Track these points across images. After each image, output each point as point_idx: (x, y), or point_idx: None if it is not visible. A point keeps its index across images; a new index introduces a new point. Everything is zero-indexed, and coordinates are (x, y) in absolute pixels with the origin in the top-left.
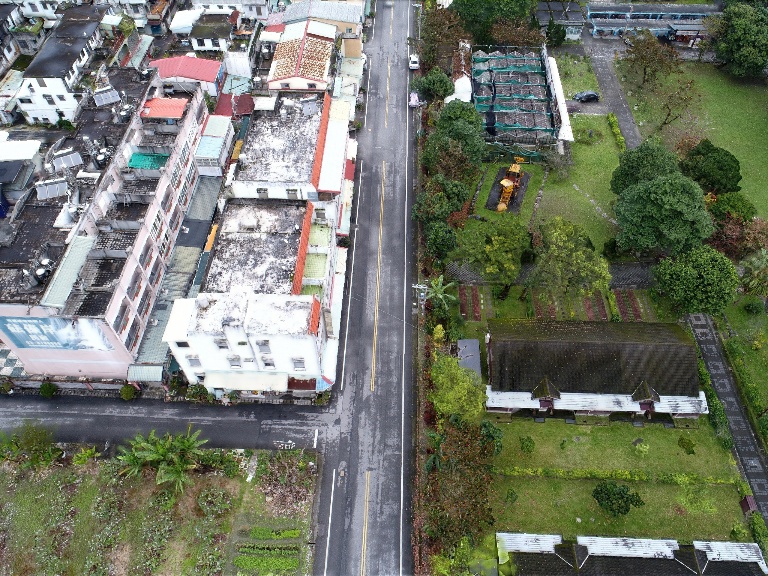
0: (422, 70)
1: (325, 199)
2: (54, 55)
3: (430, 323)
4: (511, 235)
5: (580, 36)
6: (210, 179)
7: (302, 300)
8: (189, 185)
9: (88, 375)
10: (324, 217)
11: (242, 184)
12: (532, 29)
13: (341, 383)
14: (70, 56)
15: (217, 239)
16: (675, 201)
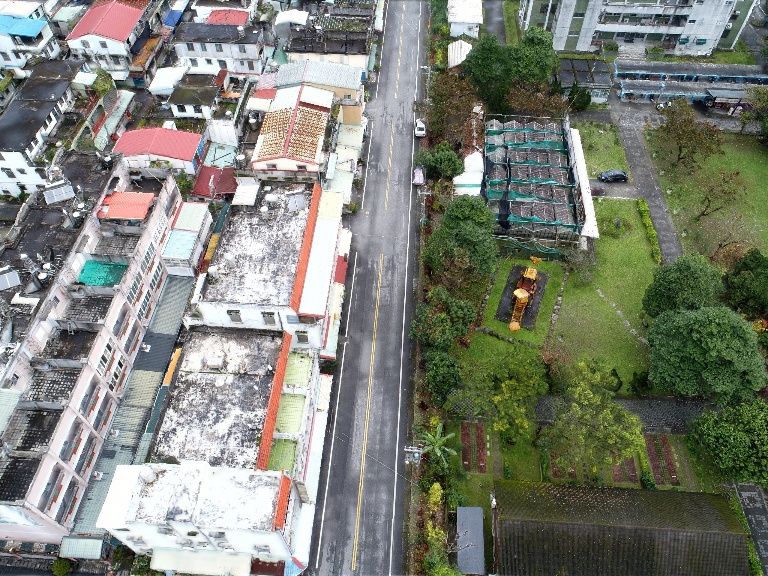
0: (429, 139)
1: (307, 322)
2: (16, 122)
3: (425, 480)
4: (525, 378)
5: (606, 99)
6: (180, 279)
7: (269, 474)
8: (154, 291)
9: (17, 540)
10: (306, 339)
11: (210, 305)
12: (553, 93)
13: (316, 558)
14: (33, 124)
15: (174, 382)
16: (723, 347)
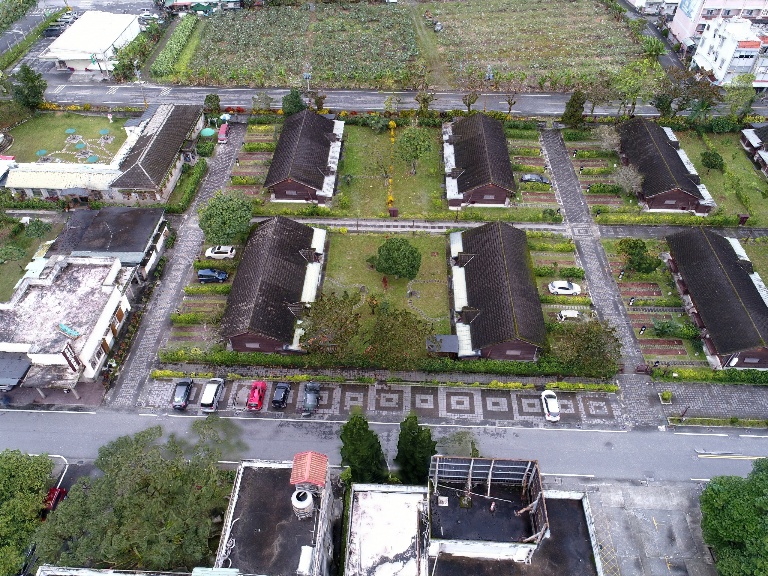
0: None
1: None
2: None
3: None
4: None
5: None
6: None
7: None
8: None
9: (678, 39)
10: None
11: None
12: None
13: None
14: None
15: None
16: None
